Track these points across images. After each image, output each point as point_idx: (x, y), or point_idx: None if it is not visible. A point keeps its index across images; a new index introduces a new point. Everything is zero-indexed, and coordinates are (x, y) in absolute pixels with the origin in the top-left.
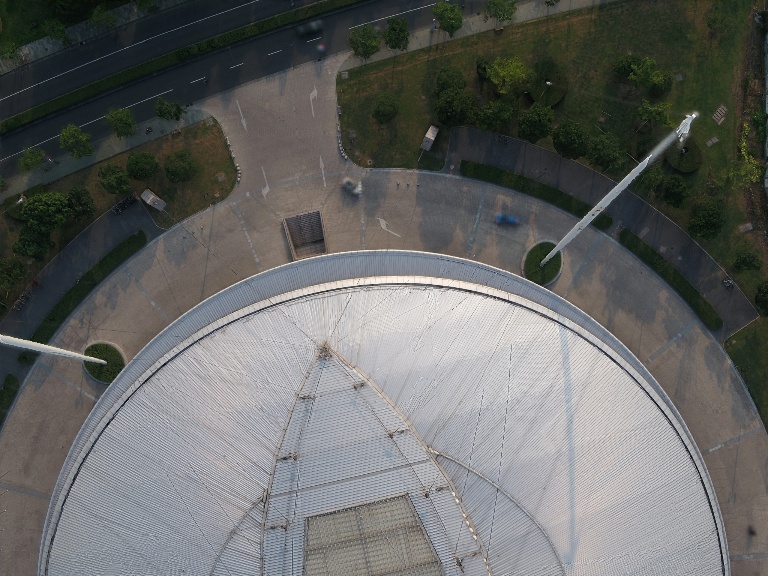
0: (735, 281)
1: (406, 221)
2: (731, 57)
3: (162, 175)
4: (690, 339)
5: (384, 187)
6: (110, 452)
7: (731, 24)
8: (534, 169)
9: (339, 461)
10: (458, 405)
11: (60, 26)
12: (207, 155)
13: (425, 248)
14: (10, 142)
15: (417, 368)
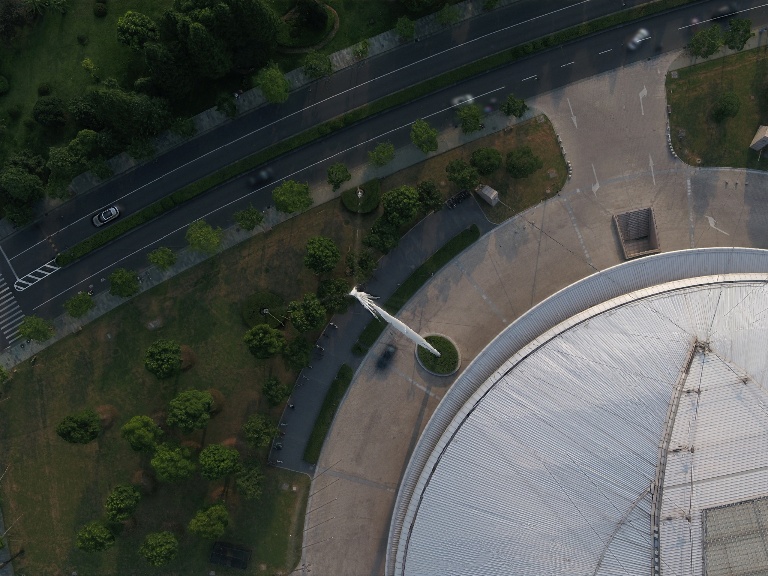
0: None
1: (734, 219)
2: None
3: (495, 171)
4: None
5: (713, 186)
6: (475, 442)
7: None
8: None
9: (732, 454)
10: None
11: (412, 23)
12: (538, 152)
13: (753, 246)
14: (345, 136)
15: None
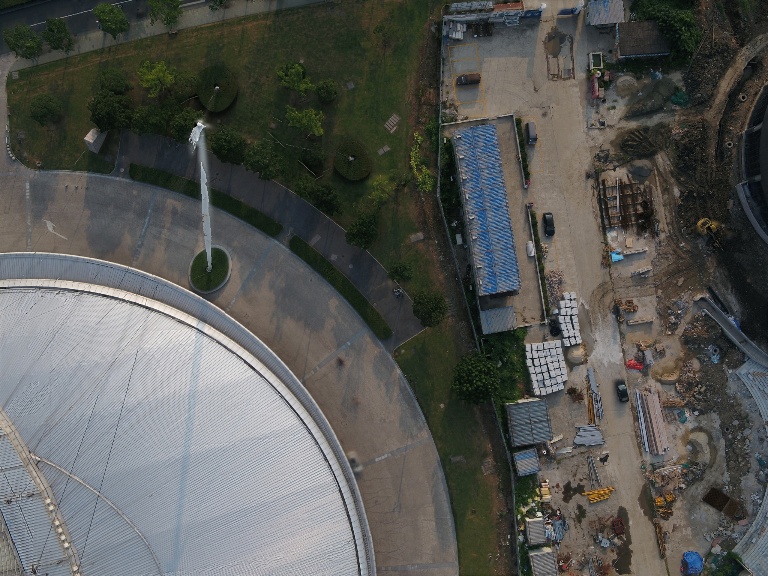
0: (405, 290)
1: (73, 224)
2: (404, 66)
3: None
4: (359, 348)
5: (52, 189)
6: None
7: (406, 33)
8: None
9: None
10: (68, 411)
11: None
12: None
13: (92, 251)
14: None
15: (31, 373)
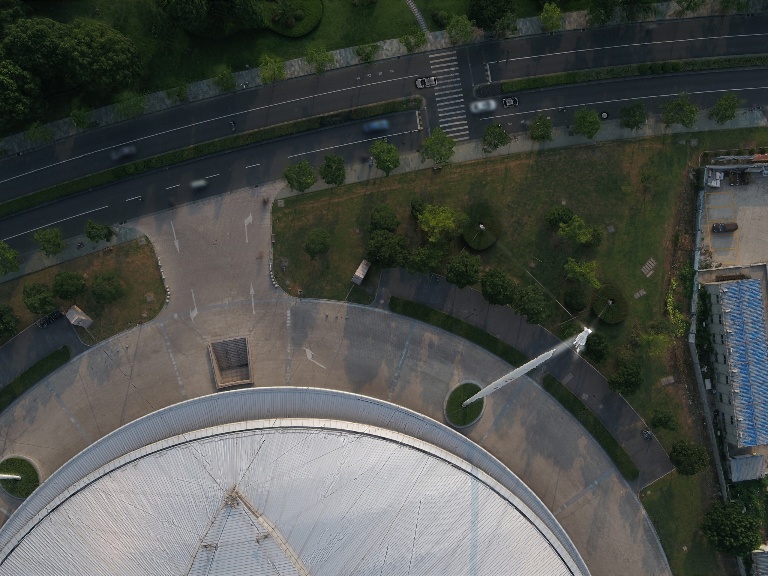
0: (654, 432)
1: (332, 353)
2: (663, 212)
3: (90, 292)
4: (606, 487)
5: (313, 317)
6: None
7: (666, 179)
8: (463, 309)
9: None
10: (361, 560)
11: None
12: (137, 274)
13: (349, 381)
14: None
15: (323, 519)
